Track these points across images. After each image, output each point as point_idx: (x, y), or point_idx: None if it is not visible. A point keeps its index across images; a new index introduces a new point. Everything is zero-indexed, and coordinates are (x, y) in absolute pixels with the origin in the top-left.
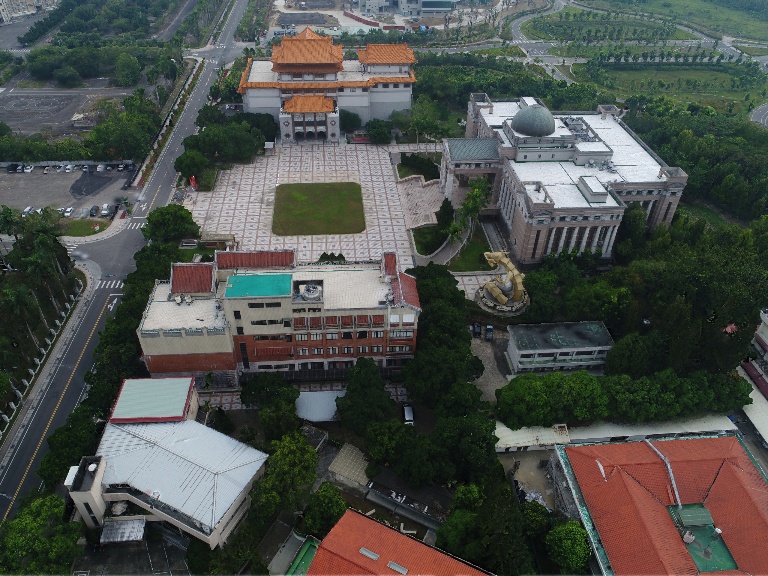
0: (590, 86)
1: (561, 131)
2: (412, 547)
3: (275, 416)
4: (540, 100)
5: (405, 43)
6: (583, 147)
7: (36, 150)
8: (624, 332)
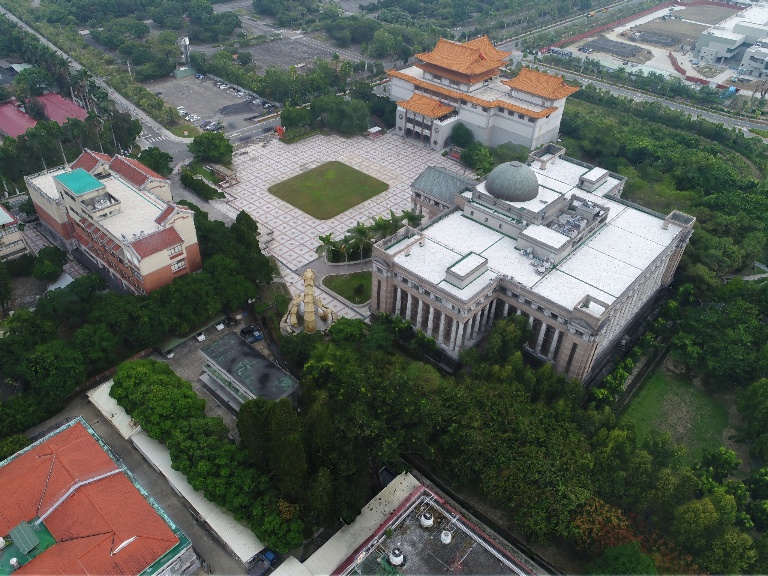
0: None
1: (533, 204)
2: None
3: None
4: (623, 180)
5: None
6: (535, 231)
7: (232, 74)
8: None
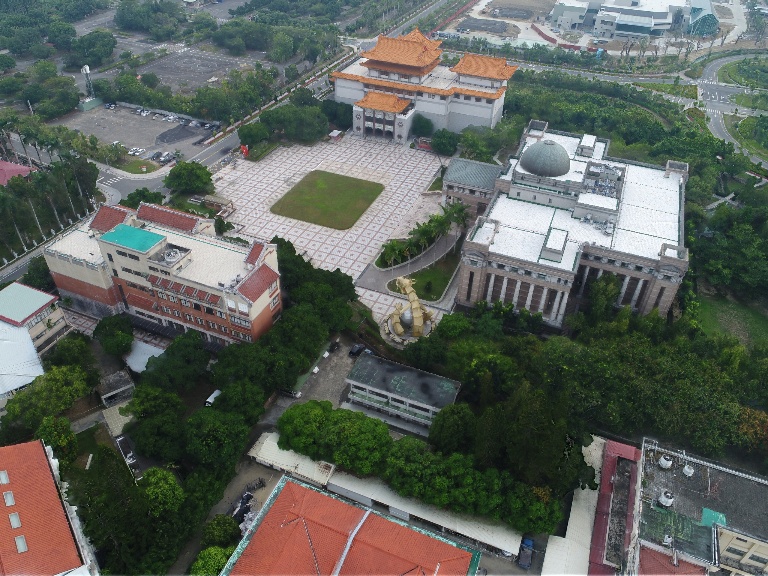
0: (730, 143)
1: (573, 176)
2: (46, 491)
3: (66, 346)
4: (608, 142)
5: (504, 58)
6: (587, 198)
7: (153, 99)
8: (480, 403)
